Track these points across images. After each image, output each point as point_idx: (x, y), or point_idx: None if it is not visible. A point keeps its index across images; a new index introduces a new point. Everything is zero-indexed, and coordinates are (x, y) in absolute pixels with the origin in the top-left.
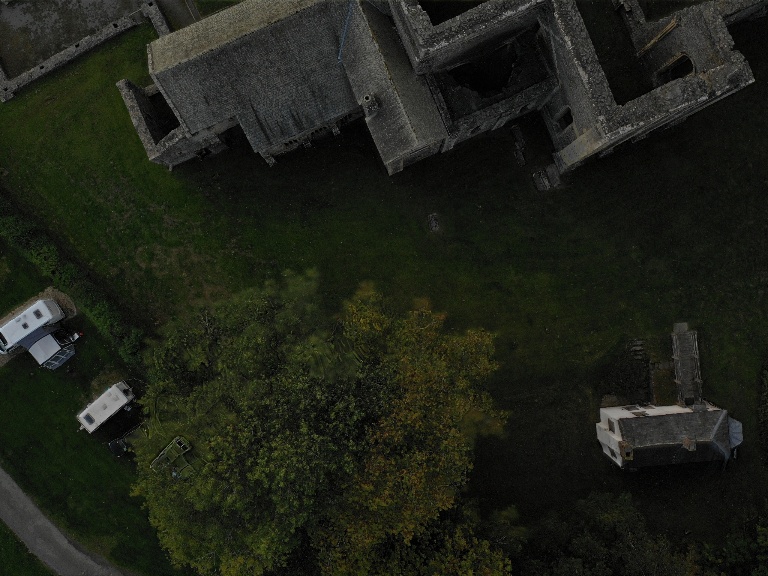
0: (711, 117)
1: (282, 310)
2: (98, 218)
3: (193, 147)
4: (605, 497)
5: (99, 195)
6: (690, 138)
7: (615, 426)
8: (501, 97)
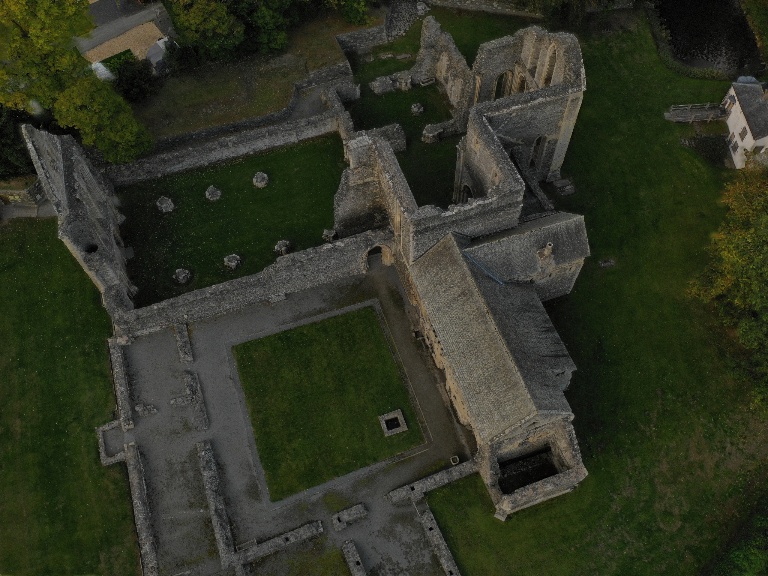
0: None
1: (767, 274)
2: (633, 570)
3: None
4: None
5: (608, 567)
6: None
7: (759, 144)
8: None
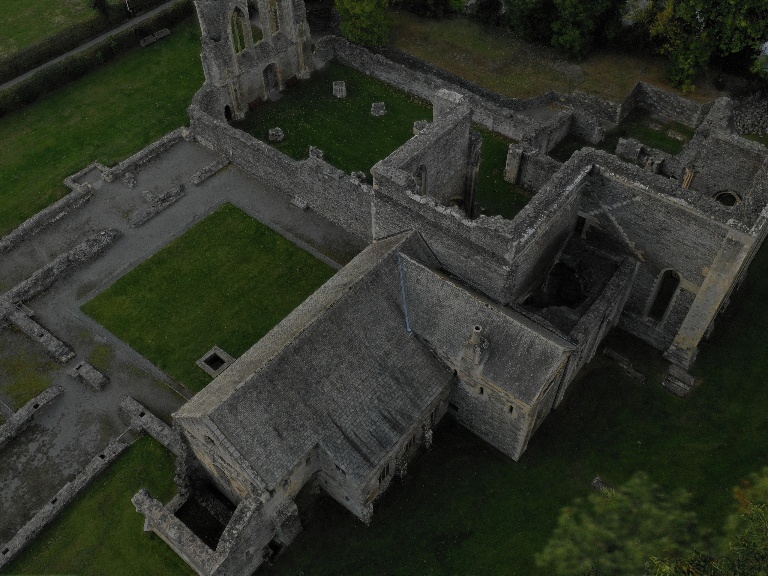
0: (762, 265)
1: None
2: None
3: (262, 537)
4: None
5: None
6: (764, 287)
7: None
8: (590, 301)
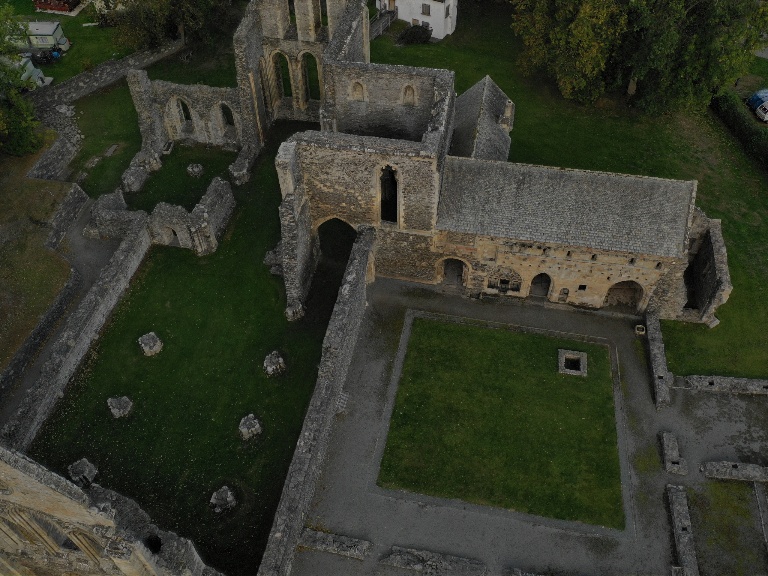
0: None
1: None
2: None
3: None
4: (471, 12)
5: None
6: None
7: (447, 4)
8: None
